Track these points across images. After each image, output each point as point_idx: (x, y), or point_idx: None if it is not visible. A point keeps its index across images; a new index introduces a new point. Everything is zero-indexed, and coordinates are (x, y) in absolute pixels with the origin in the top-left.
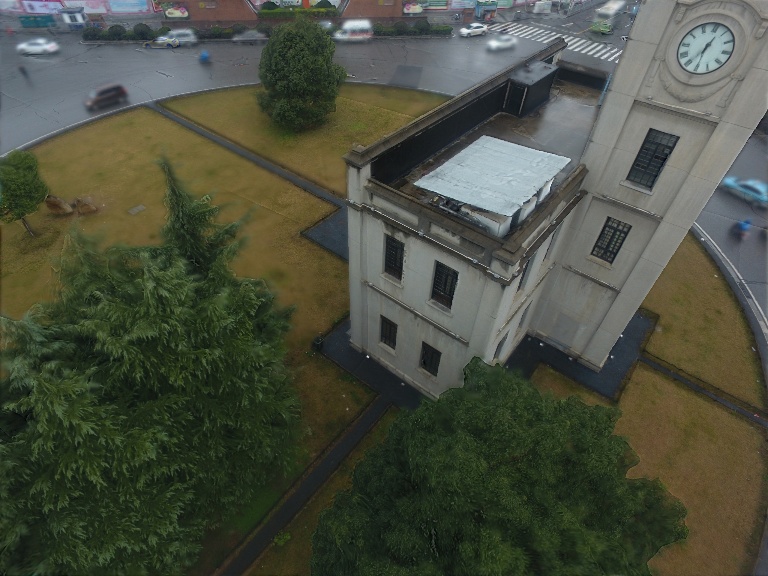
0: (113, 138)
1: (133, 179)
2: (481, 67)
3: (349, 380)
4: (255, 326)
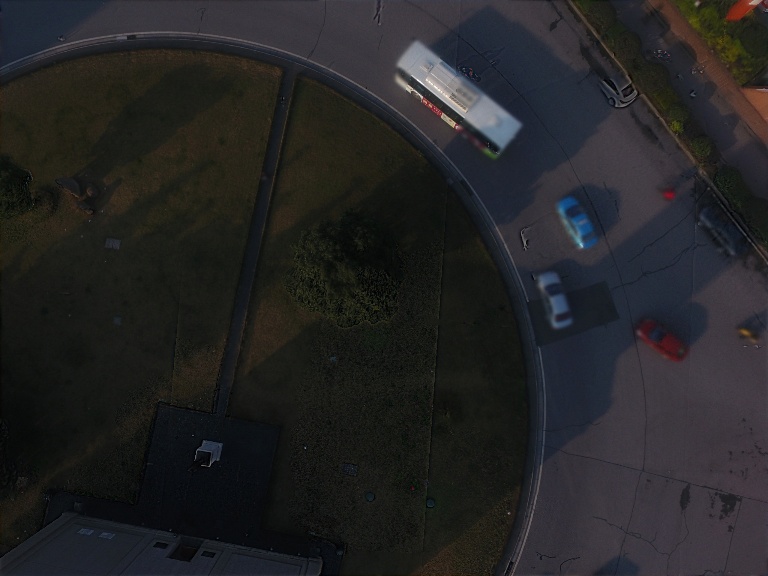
0: (201, 109)
1: (147, 200)
2: (676, 399)
3: (37, 528)
4: None
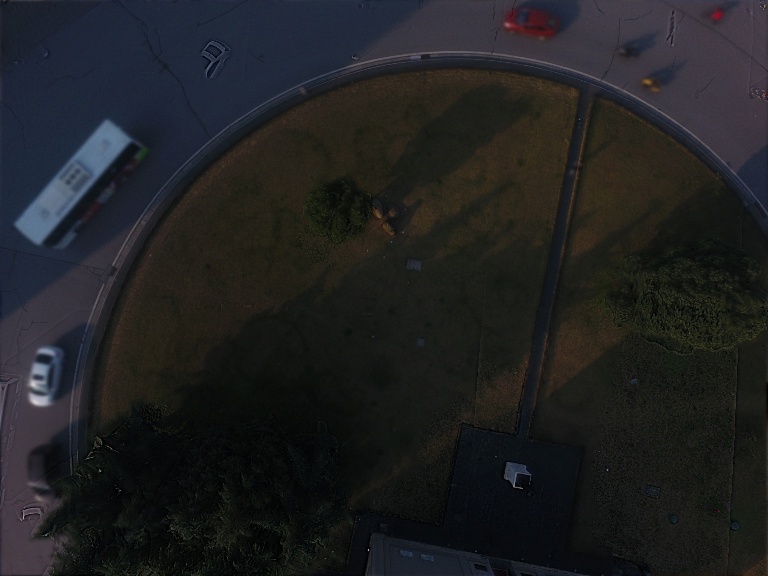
0: (499, 130)
1: (449, 221)
2: None
3: (345, 549)
4: (288, 567)
